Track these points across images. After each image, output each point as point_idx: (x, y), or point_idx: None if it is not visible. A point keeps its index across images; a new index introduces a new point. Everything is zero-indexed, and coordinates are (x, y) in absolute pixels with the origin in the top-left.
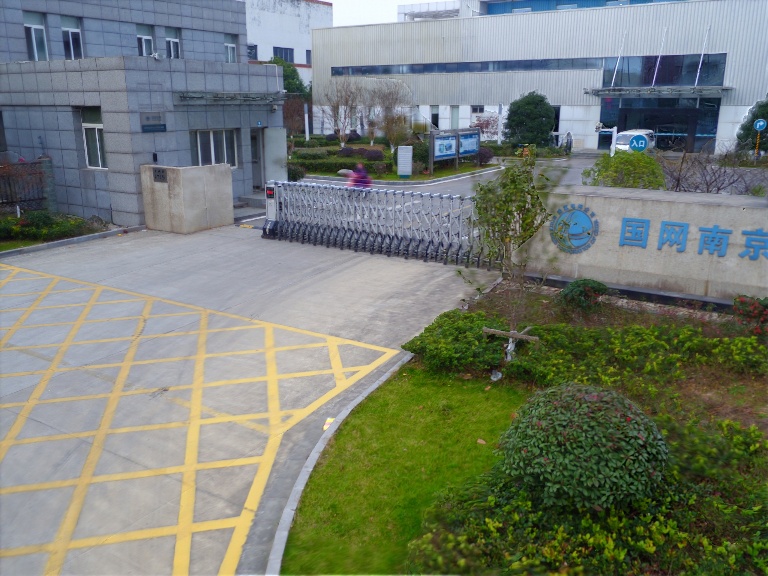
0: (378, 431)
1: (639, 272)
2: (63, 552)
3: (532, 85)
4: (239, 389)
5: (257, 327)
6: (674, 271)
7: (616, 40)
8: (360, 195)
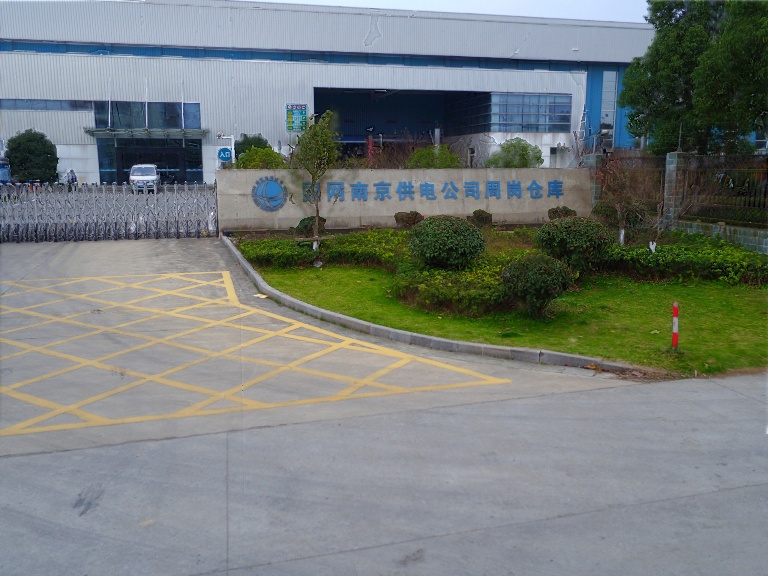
0: (301, 289)
1: None
2: (228, 354)
3: (20, 124)
4: (159, 300)
5: (85, 280)
6: (340, 214)
7: (102, 86)
8: (53, 188)
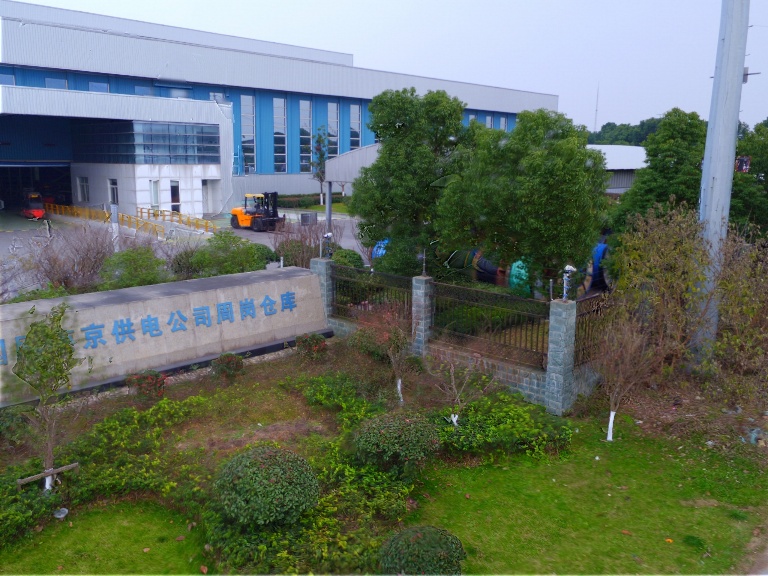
0: None
1: (8, 387)
2: None
3: None
4: None
5: None
6: None
7: None
8: None
